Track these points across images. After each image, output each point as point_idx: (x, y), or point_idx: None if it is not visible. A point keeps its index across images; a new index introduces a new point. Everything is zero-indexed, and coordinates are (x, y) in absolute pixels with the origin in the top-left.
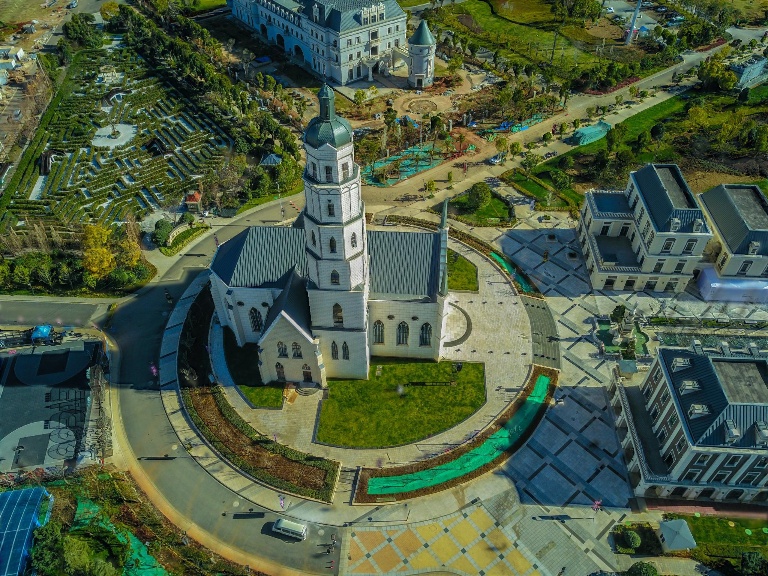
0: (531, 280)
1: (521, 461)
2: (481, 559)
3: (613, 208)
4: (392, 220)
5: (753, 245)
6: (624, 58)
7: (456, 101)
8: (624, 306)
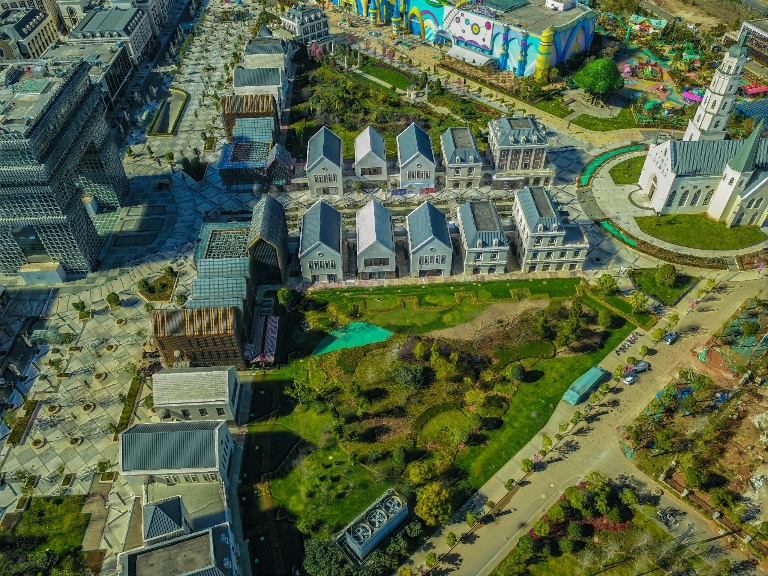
0: (604, 230)
1: (586, 159)
2: (593, 136)
3: (568, 234)
4: (721, 261)
5: None
6: None
7: (767, 440)
8: None
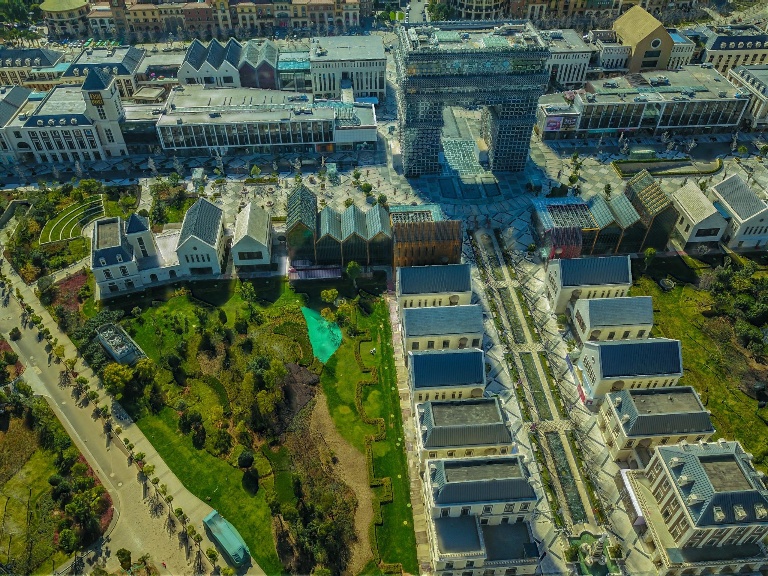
0: None
1: None
2: None
3: (463, 534)
4: None
5: (510, 426)
6: (8, 464)
7: None
8: (575, 547)
